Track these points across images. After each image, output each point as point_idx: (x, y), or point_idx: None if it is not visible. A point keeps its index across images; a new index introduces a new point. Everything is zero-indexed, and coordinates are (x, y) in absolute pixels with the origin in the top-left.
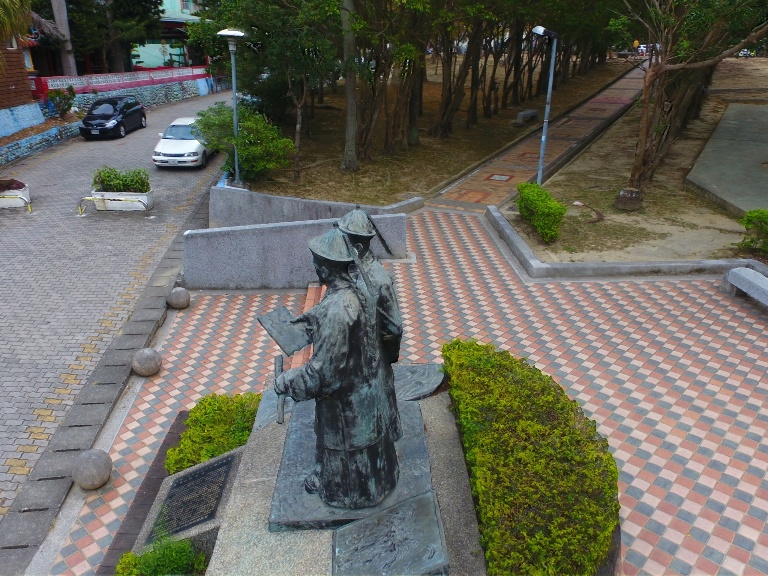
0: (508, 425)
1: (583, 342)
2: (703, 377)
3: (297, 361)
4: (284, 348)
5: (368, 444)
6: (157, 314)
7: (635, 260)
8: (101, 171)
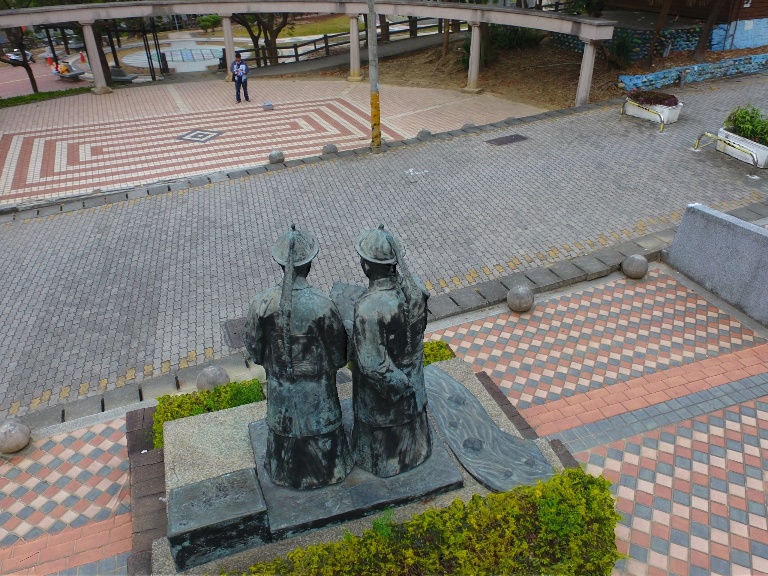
0: (428, 571)
1: None
2: None
3: (612, 389)
4: None
5: (274, 429)
6: (596, 268)
7: None
8: (740, 109)
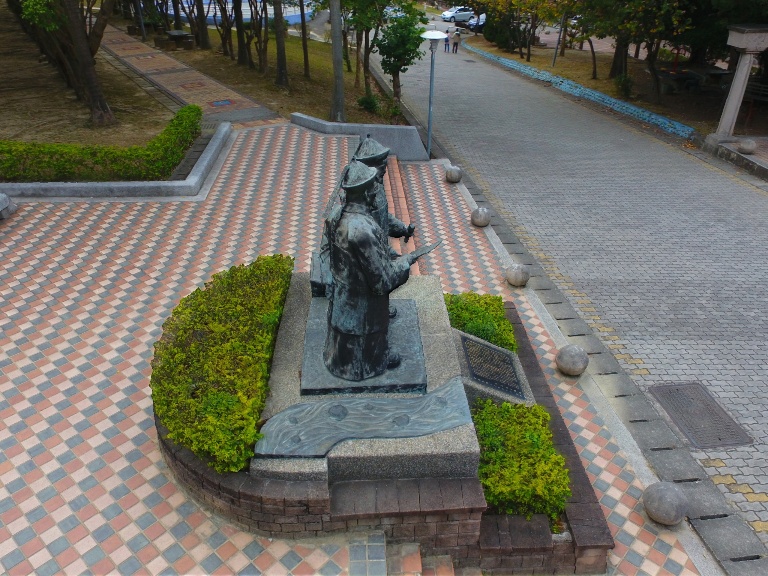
0: None
1: None
2: None
3: None
4: None
5: None
6: None
7: None
8: None
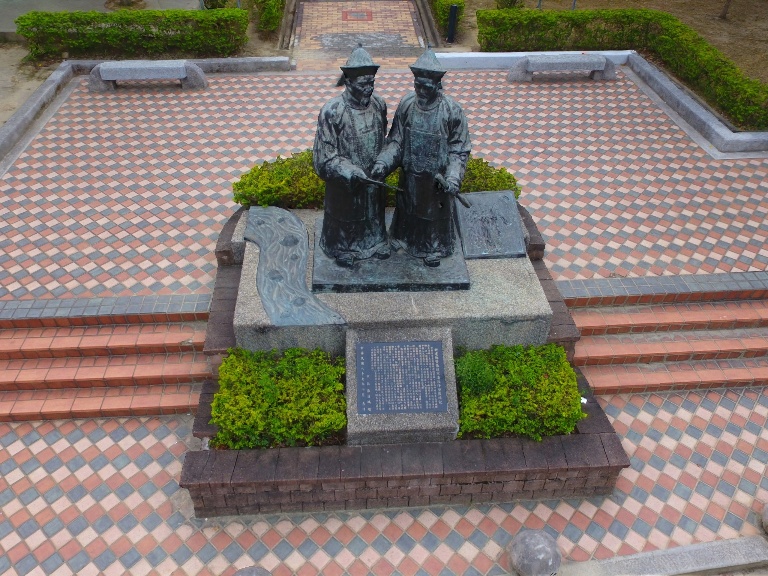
0: None
1: (161, 166)
2: (237, 130)
3: (36, 406)
4: (399, 188)
5: None
6: None
7: (0, 110)
8: None
